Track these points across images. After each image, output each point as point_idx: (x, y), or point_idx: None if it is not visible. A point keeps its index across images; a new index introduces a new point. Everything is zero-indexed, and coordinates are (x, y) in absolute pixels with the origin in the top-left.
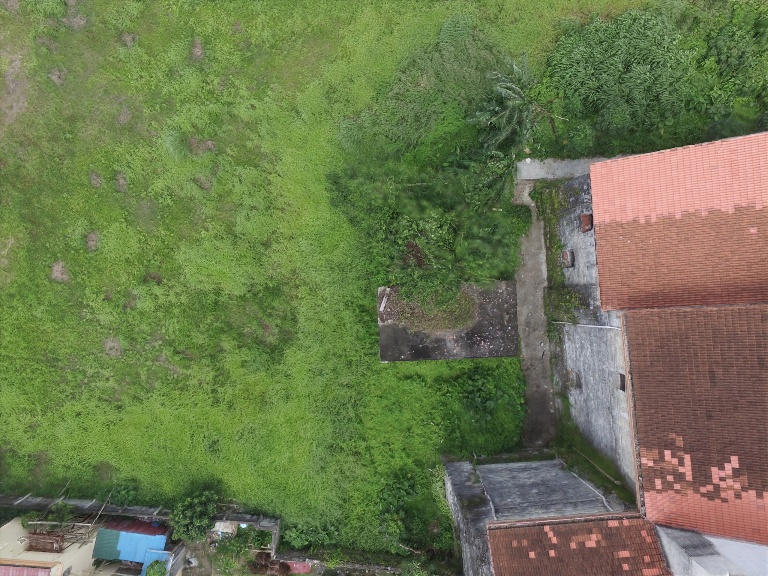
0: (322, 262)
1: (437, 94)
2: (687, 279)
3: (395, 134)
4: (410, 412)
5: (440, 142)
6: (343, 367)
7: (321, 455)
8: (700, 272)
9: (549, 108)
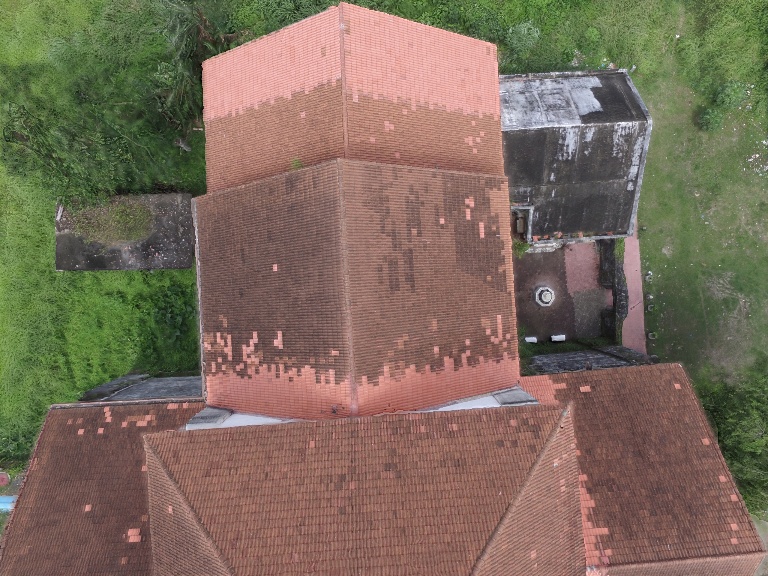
0: (27, 178)
1: (148, 15)
2: (261, 168)
3: (103, 54)
4: (109, 328)
5: (149, 63)
6: (46, 282)
7: (17, 367)
8: (268, 160)
9: (252, 30)
